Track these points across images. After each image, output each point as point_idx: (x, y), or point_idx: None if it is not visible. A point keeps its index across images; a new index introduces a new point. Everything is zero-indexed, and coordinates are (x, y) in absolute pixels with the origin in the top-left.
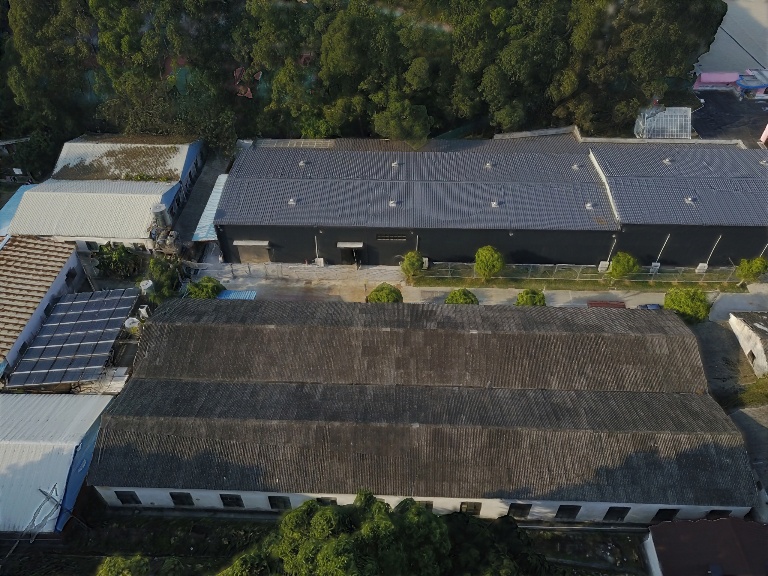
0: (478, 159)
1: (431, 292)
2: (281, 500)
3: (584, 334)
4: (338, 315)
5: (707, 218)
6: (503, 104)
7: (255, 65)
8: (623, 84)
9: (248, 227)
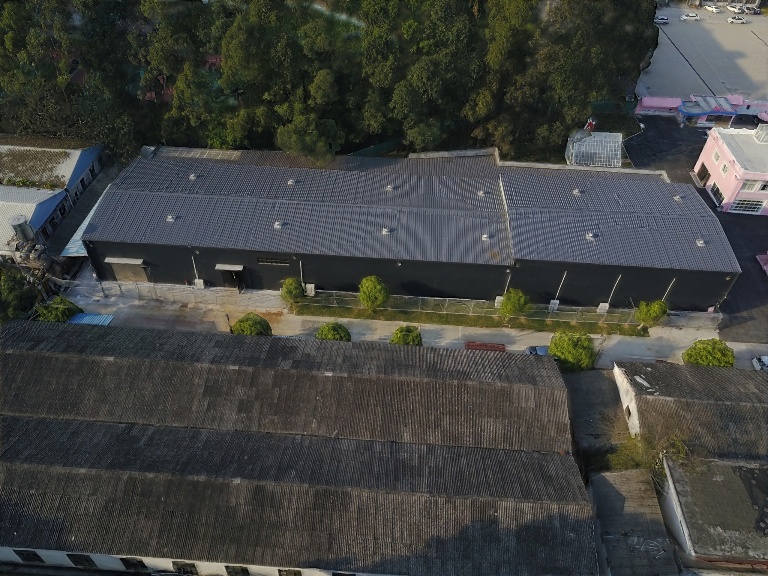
0: (381, 180)
1: (312, 322)
2: (83, 558)
3: (447, 381)
4: (189, 348)
5: (605, 256)
6: (418, 122)
7: (153, 69)
8: (547, 106)
9: (119, 244)
